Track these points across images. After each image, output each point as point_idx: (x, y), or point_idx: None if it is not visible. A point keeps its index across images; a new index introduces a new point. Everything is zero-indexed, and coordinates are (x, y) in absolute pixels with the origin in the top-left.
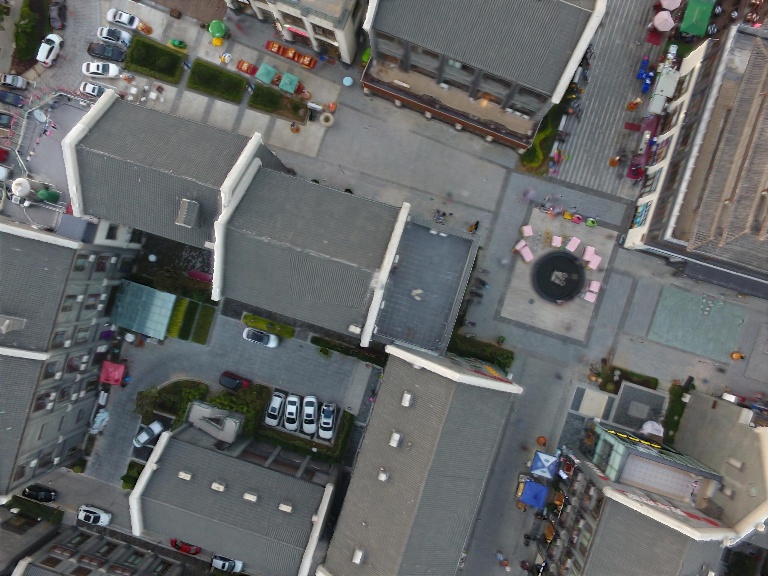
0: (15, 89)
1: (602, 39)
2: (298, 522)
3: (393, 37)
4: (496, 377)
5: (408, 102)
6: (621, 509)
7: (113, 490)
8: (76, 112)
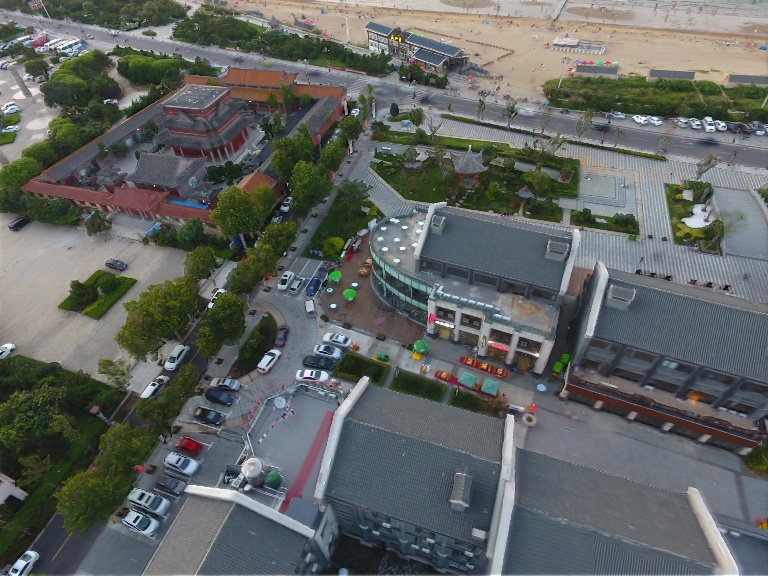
0: (227, 390)
1: None
2: None
3: (608, 344)
4: None
5: (609, 404)
6: None
7: None
8: (311, 401)
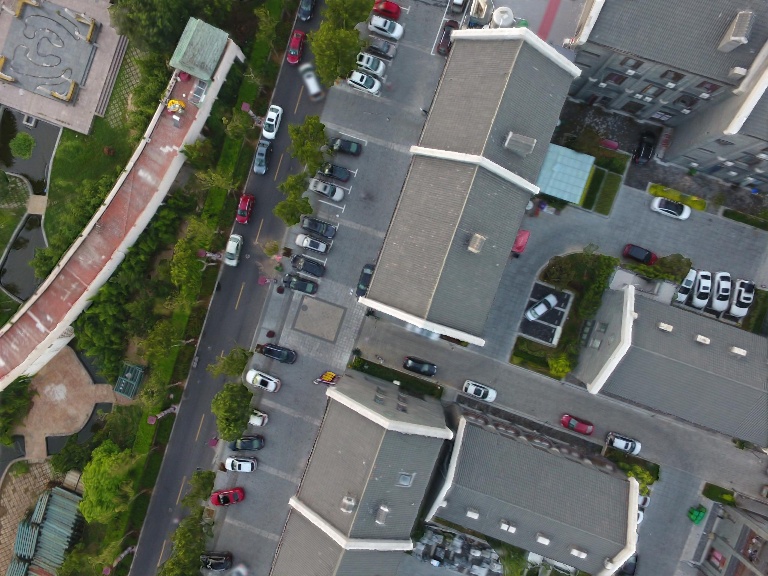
0: None
1: None
2: None
3: None
4: None
5: None
6: None
7: (497, 366)
8: None
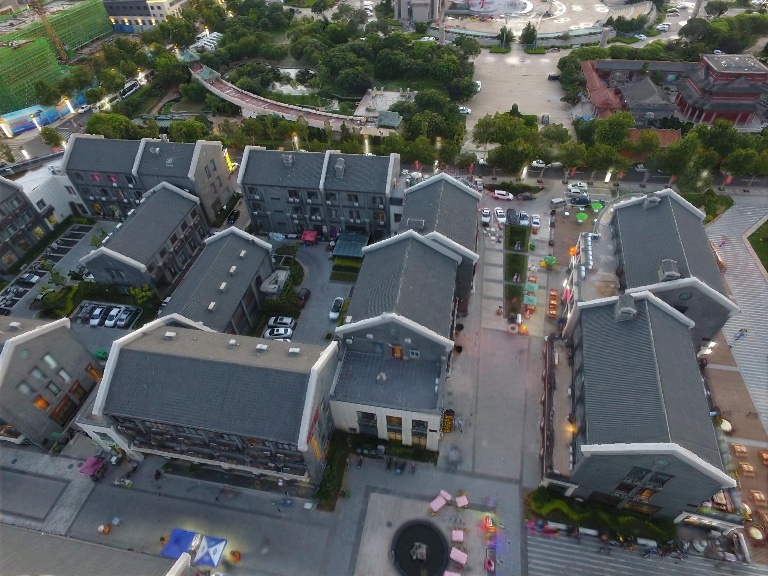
0: None
1: (701, 569)
2: (199, 314)
3: None
4: (312, 434)
5: None
6: (164, 573)
7: None
8: None
